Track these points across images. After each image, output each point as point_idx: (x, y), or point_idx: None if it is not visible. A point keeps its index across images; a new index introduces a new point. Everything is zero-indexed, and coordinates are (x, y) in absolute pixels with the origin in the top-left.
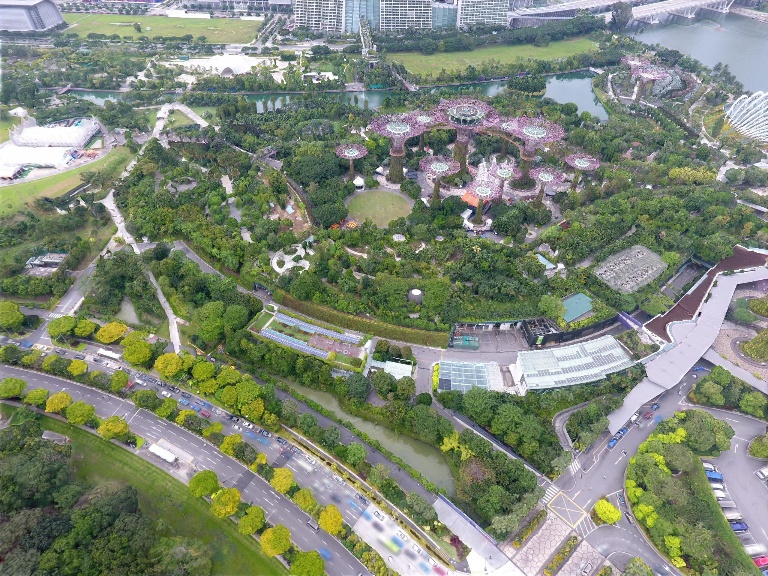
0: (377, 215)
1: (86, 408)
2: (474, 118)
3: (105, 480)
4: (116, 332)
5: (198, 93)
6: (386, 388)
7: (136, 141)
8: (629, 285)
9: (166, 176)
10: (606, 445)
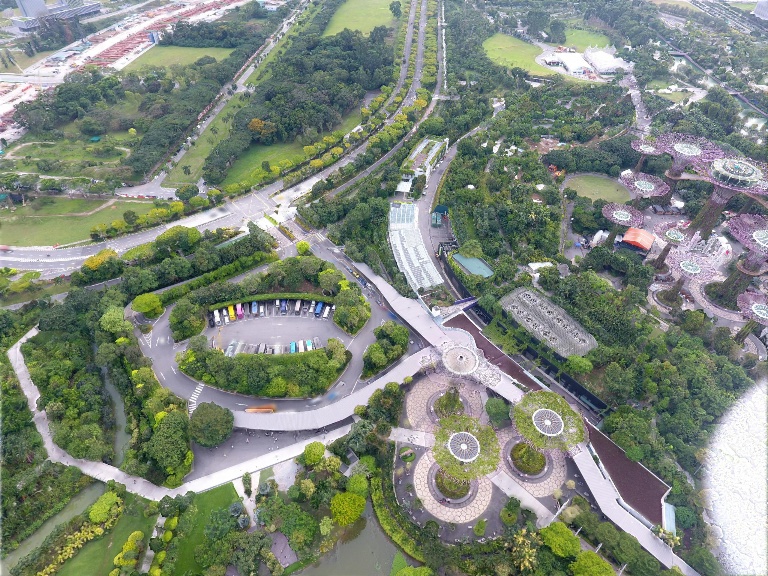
0: (584, 189)
1: (376, 105)
2: (723, 172)
3: (347, 122)
4: (419, 102)
5: (721, 89)
6: (388, 177)
7: (619, 84)
8: (515, 310)
9: (577, 99)
10: (349, 267)
